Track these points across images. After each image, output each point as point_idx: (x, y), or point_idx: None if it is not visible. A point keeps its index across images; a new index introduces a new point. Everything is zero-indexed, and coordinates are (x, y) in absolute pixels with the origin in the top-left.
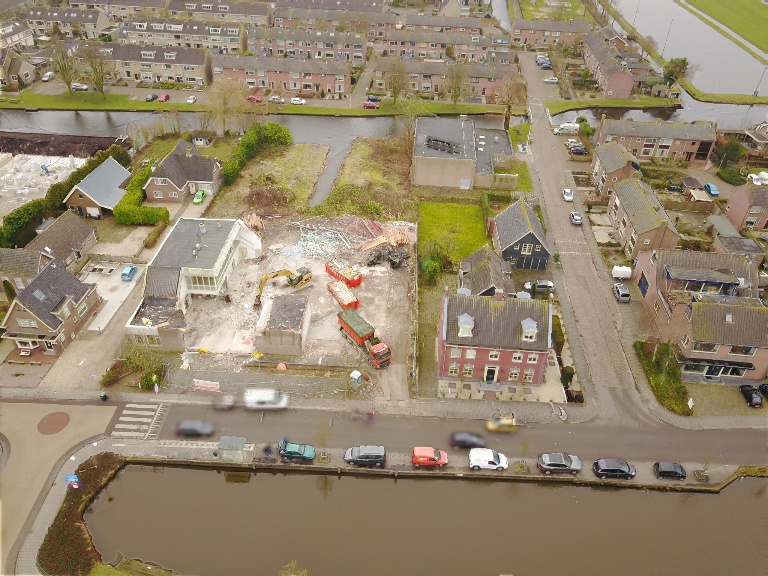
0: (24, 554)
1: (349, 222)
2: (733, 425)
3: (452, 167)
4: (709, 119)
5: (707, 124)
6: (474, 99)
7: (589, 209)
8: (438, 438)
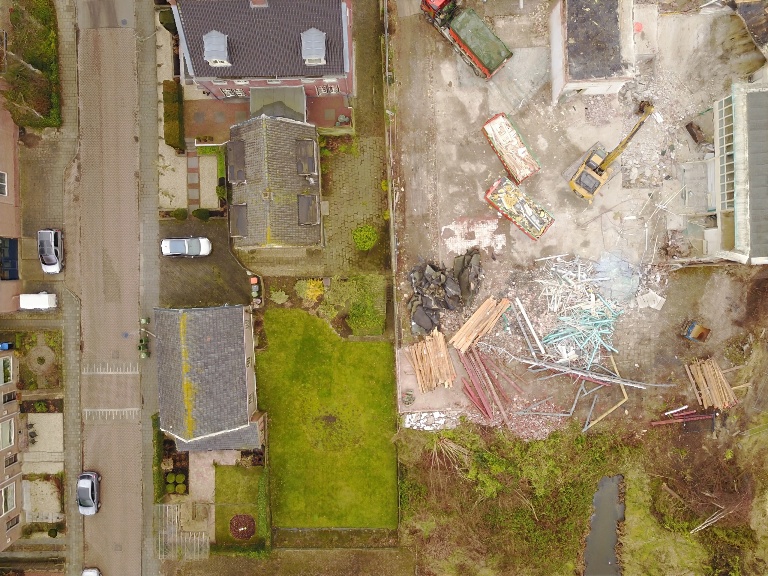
0: None
1: (530, 406)
2: None
3: None
4: None
5: None
6: None
7: (56, 530)
8: None
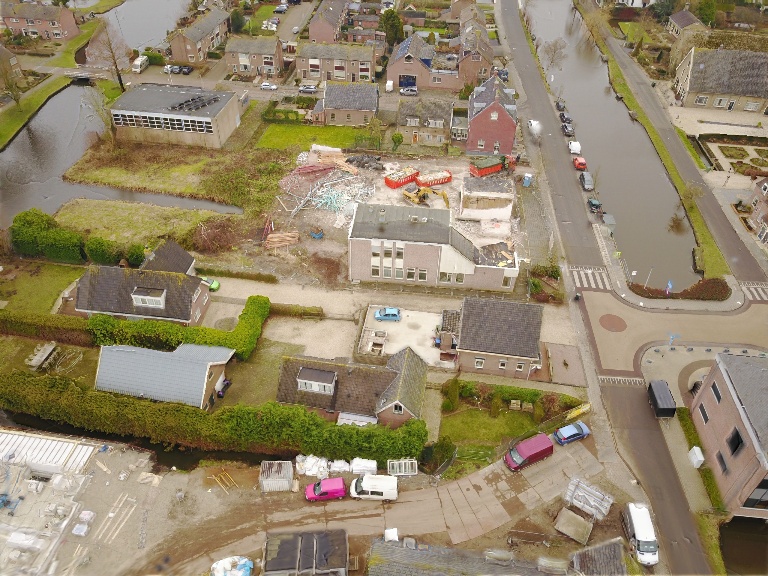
0: (723, 308)
1: (298, 181)
2: (522, 88)
3: (230, 110)
4: (172, 12)
5: (214, 6)
6: (6, 96)
7: None
8: (561, 162)
